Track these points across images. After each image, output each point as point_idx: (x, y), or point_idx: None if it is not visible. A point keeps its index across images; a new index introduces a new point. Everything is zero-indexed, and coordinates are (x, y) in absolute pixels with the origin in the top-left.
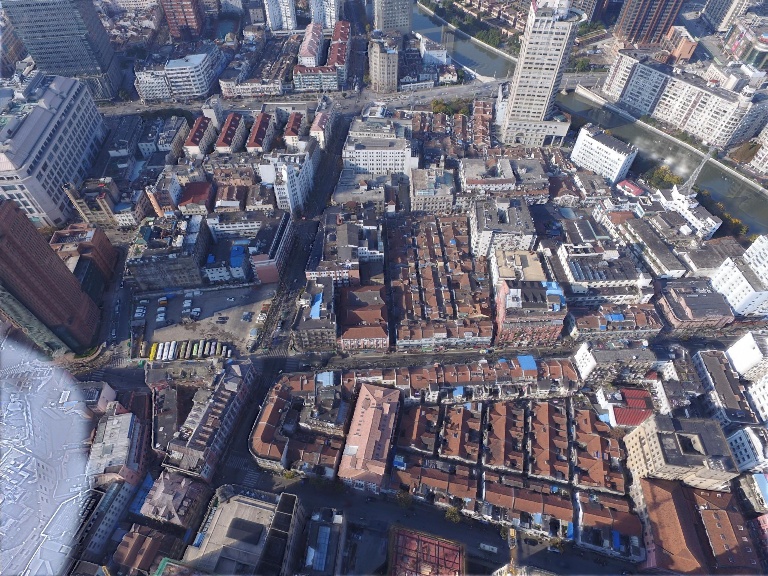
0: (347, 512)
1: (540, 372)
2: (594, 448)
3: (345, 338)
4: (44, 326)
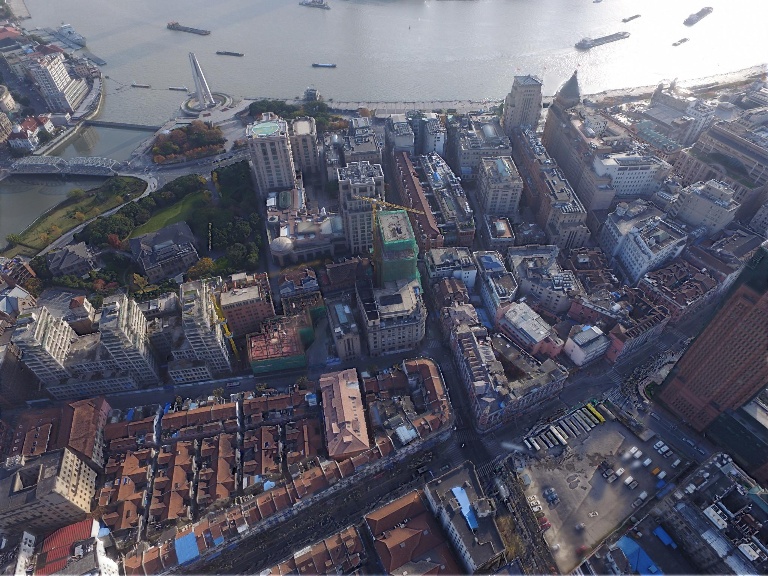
0: (344, 369)
1: (172, 542)
2: (127, 488)
3: (413, 493)
4: (683, 354)
